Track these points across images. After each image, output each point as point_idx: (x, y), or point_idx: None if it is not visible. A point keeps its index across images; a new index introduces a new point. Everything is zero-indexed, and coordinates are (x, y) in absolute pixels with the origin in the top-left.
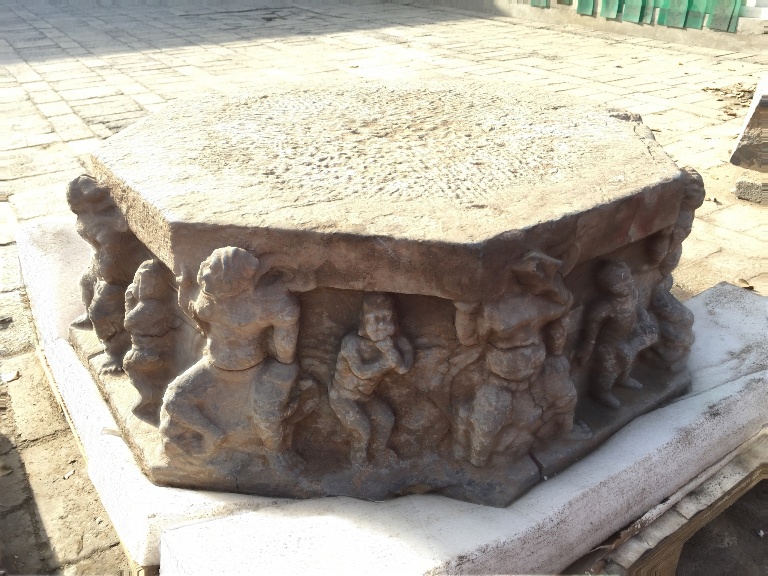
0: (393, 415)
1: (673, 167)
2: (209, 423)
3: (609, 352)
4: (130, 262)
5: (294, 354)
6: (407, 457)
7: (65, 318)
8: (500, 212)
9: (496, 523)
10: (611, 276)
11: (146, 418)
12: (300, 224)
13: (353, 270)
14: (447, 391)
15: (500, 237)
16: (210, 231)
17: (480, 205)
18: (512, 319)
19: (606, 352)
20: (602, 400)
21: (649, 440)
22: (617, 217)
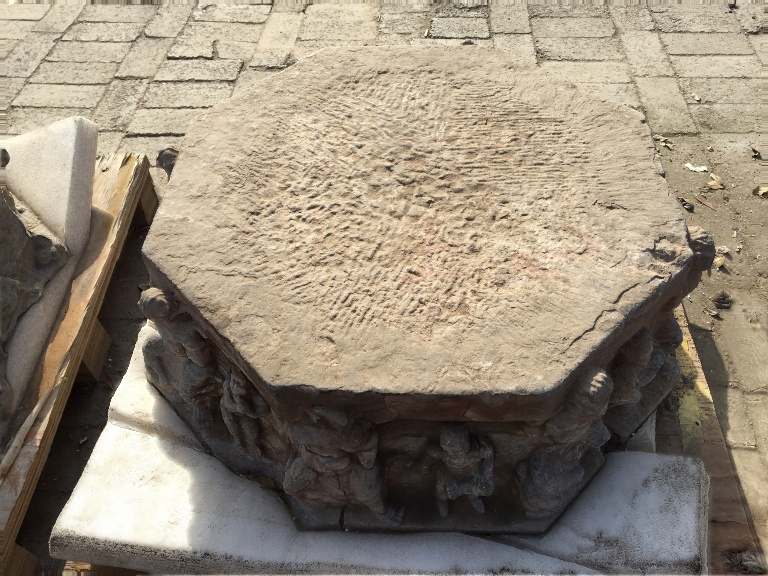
0: (257, 432)
1: (559, 376)
2: (161, 371)
3: (441, 480)
4: None
5: (208, 362)
6: (269, 458)
7: None
8: (336, 356)
9: (261, 544)
10: (441, 436)
11: None
12: (197, 298)
13: None
14: (287, 442)
15: (297, 387)
16: None
17: (332, 339)
18: (301, 440)
19: (439, 478)
20: (435, 504)
21: (428, 559)
22: (442, 404)
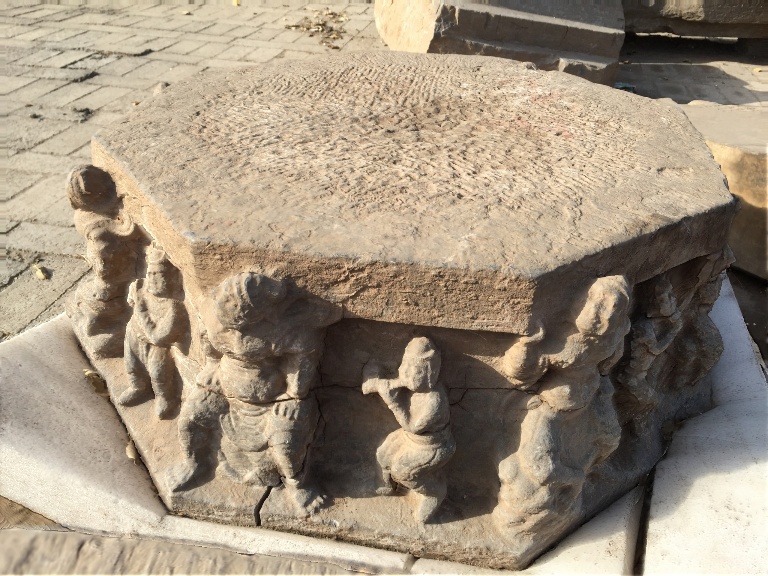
0: None
1: None
2: (573, 470)
3: None
4: (333, 359)
5: None
6: None
7: (133, 491)
8: (680, 170)
9: (762, 413)
10: None
11: (444, 518)
12: (627, 232)
13: (660, 259)
14: None
15: None
16: (570, 271)
17: (660, 169)
18: None
19: None
20: None
21: (724, 311)
22: None
